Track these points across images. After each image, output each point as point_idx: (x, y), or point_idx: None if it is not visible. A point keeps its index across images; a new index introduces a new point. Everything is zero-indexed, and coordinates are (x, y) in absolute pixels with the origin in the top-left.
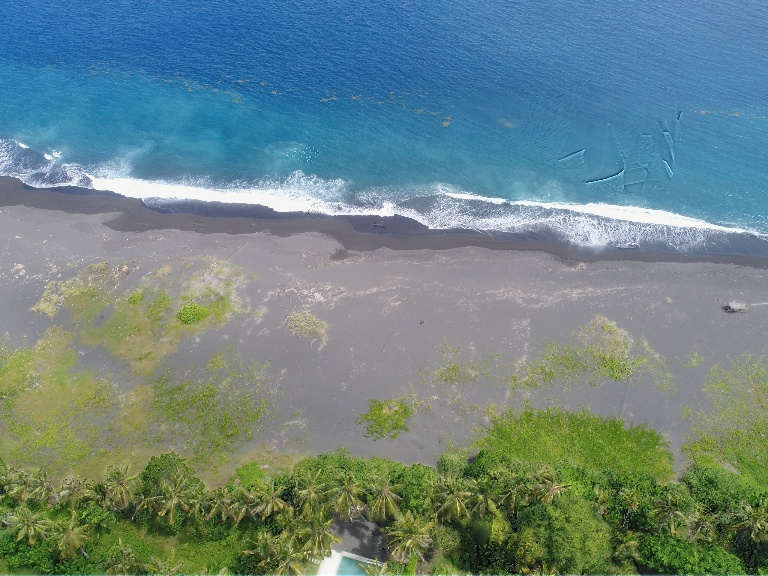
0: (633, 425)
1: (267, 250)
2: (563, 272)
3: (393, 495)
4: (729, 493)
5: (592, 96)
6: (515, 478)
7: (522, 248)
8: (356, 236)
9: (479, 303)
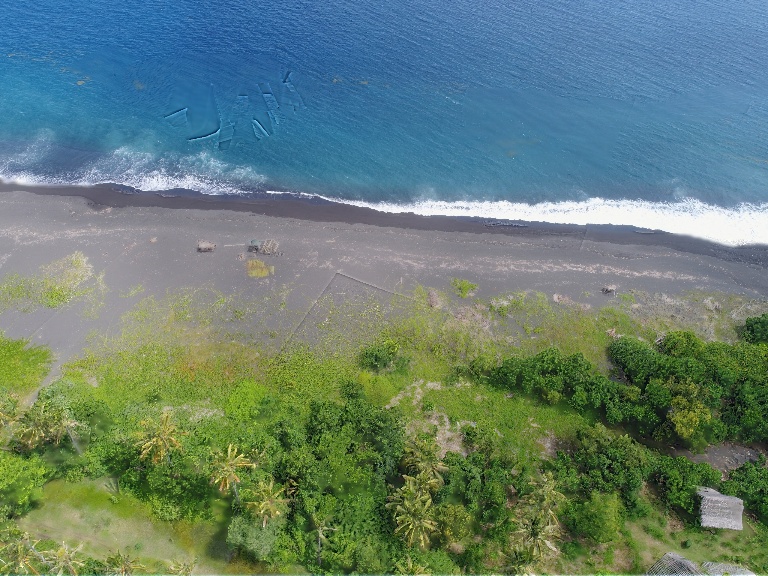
0: (34, 346)
1: None
2: (83, 215)
3: None
4: None
5: (194, 57)
6: None
7: (66, 194)
8: None
9: None
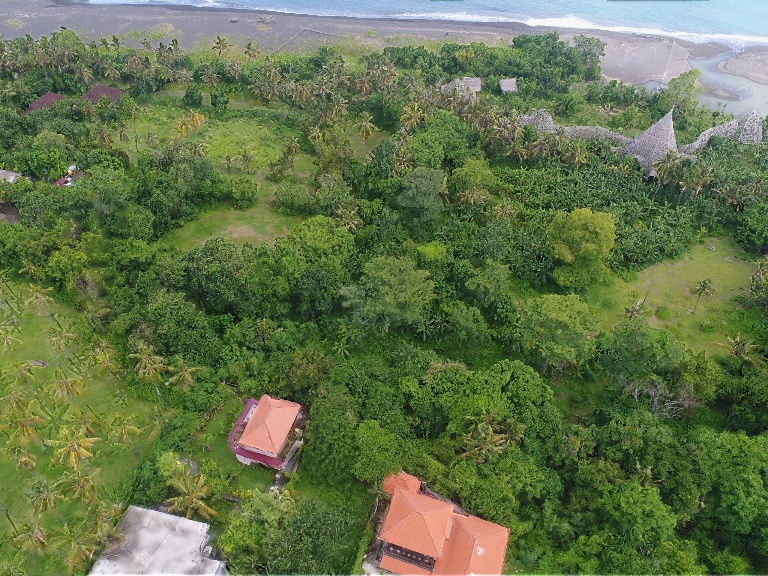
0: None
1: (11, 3)
2: None
3: (5, 44)
4: None
5: None
6: (54, 33)
7: None
8: (66, 2)
9: (109, 19)
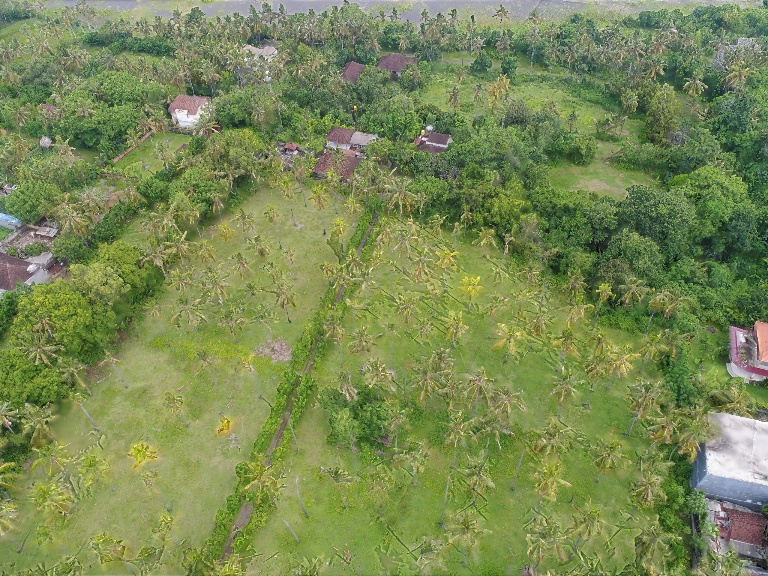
0: None
1: None
2: None
3: None
4: None
5: None
6: None
7: None
8: None
9: None
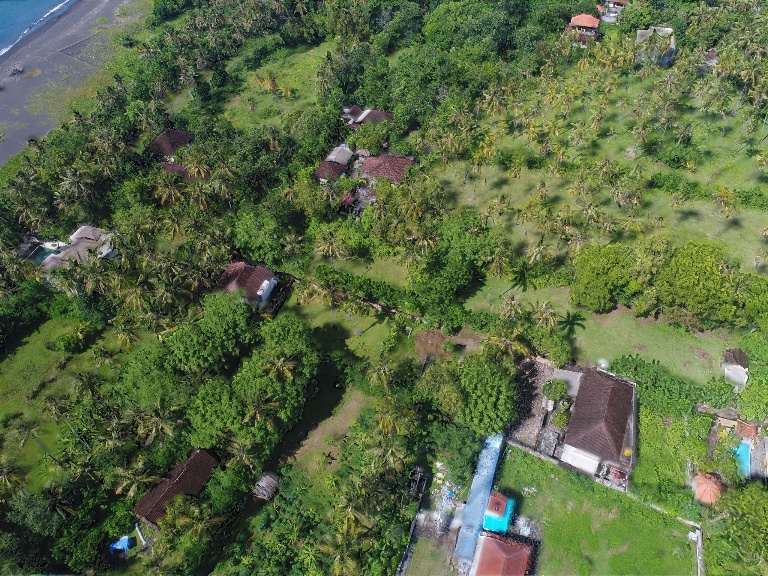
0: None
1: None
2: None
3: None
4: None
5: None
6: (24, 156)
7: None
8: None
9: None
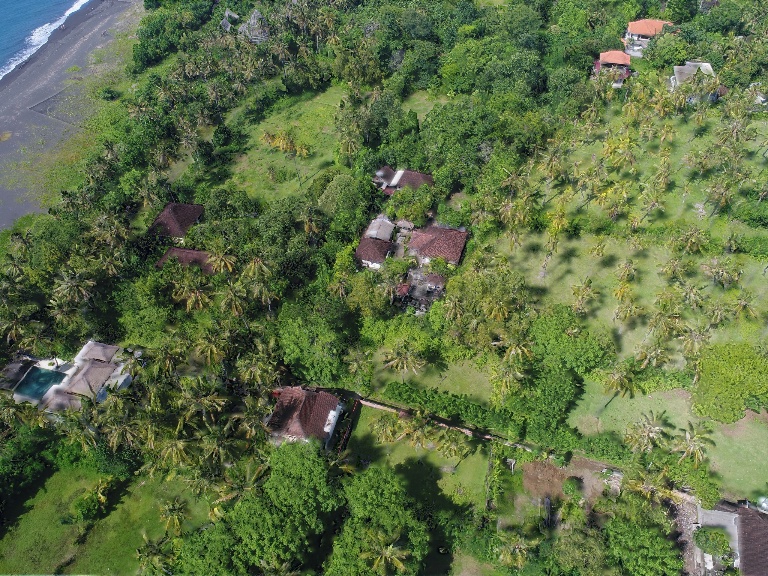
0: (11, 226)
1: None
2: None
3: None
4: (77, 192)
5: None
6: (7, 255)
7: None
8: None
9: None
